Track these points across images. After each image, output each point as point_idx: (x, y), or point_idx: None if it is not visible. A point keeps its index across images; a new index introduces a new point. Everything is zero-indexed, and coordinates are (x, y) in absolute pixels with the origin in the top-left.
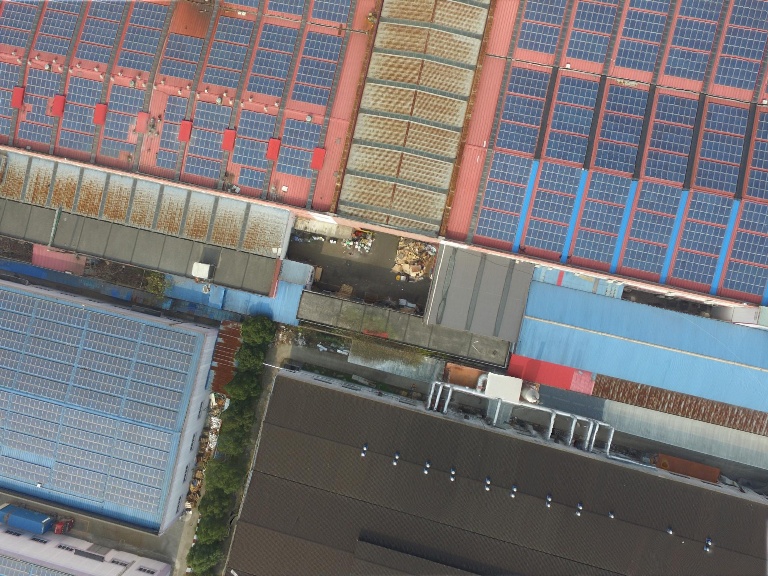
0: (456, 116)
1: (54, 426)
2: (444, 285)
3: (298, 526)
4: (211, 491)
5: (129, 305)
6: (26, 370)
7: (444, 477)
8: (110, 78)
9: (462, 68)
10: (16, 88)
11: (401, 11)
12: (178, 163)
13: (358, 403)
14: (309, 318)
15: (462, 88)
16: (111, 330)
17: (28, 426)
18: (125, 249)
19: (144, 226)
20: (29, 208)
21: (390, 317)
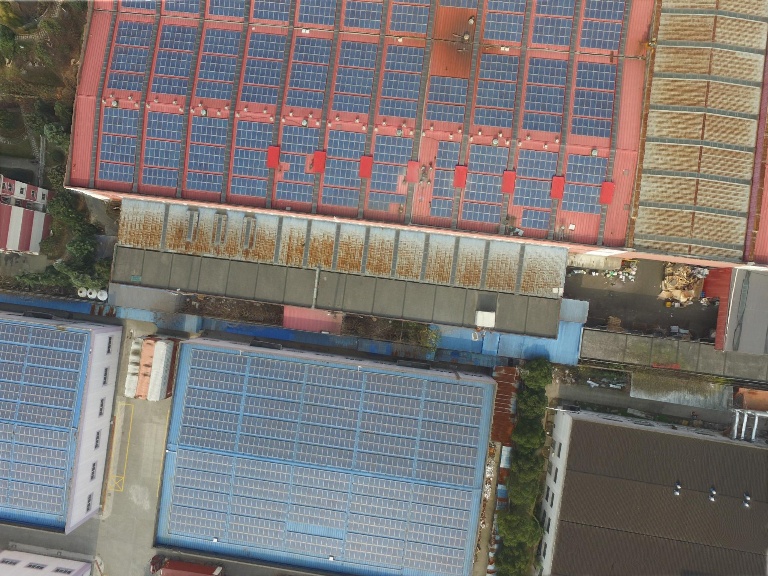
0: (747, 136)
1: (343, 495)
2: (739, 310)
3: (614, 573)
4: (515, 546)
5: (382, 359)
6: (305, 440)
7: (767, 508)
8: (374, 129)
9: (749, 86)
10: (271, 148)
11: (677, 32)
12: (454, 210)
13: (658, 440)
14: (593, 356)
15: (750, 106)
16: (391, 389)
17: (314, 498)
18: (394, 304)
19: (411, 278)
20: (284, 270)
21: (680, 347)
